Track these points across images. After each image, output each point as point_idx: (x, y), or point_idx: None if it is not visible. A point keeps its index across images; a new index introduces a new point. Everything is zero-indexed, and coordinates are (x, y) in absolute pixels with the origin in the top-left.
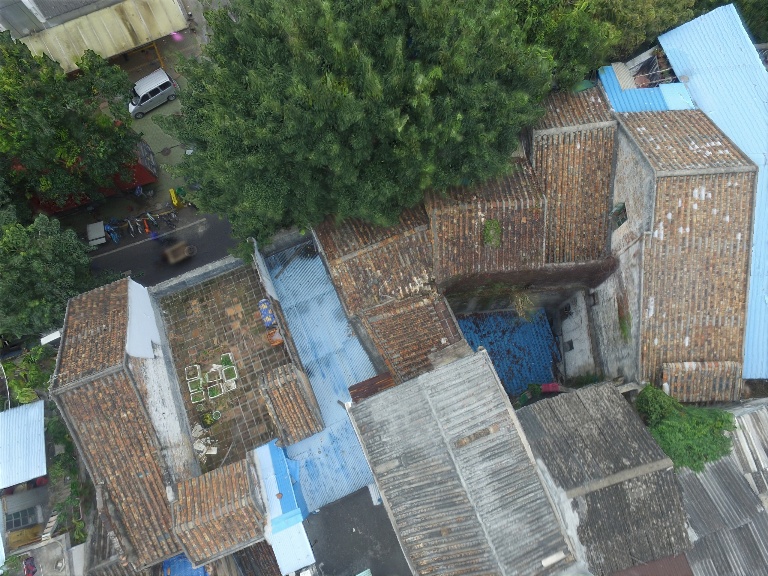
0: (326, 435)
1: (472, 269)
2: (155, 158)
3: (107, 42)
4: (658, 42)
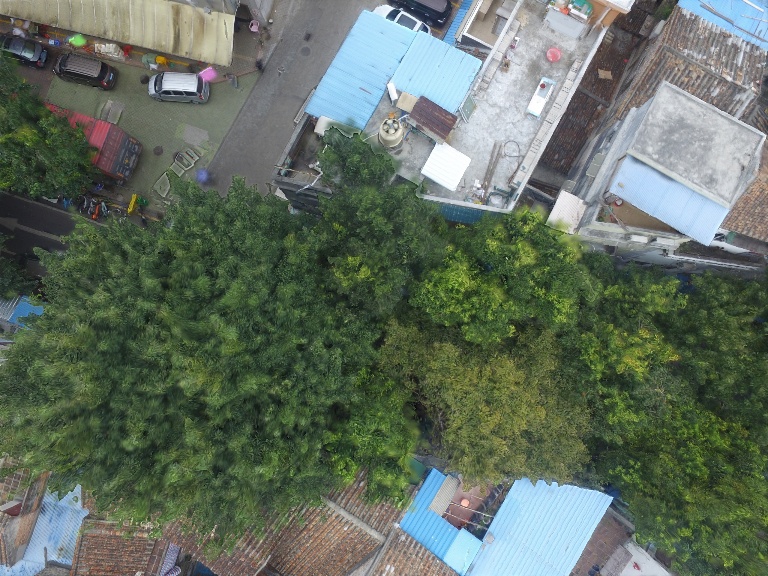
0: (20, 564)
1: (188, 552)
2: (145, 151)
3: (150, 31)
4: (514, 480)
